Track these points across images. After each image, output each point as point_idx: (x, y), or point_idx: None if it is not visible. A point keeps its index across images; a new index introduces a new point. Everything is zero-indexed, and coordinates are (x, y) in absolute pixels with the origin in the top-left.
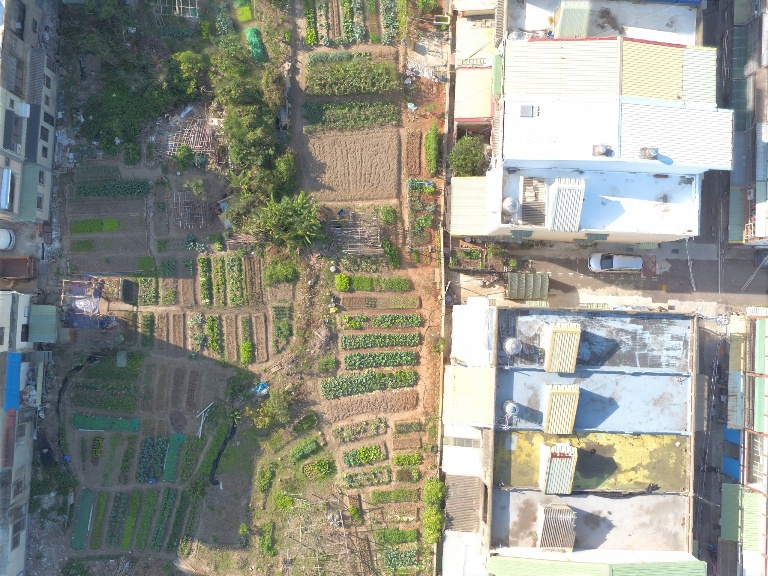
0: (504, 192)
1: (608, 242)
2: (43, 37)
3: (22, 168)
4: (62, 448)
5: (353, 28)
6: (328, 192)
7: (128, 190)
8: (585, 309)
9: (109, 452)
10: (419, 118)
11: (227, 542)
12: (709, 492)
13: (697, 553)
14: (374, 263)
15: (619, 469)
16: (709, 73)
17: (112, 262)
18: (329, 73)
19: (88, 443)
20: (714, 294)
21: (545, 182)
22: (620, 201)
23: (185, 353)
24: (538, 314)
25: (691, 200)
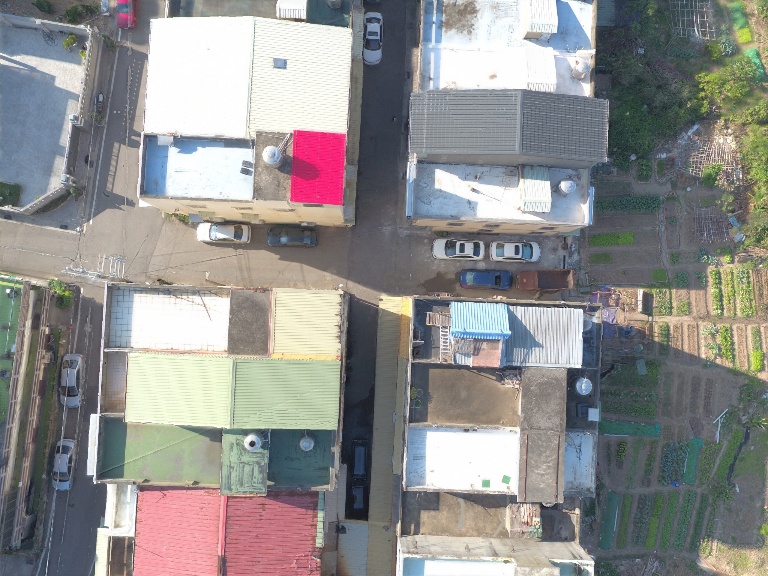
0: None
1: None
2: None
3: None
4: None
5: None
6: None
7: (643, 205)
8: None
9: (632, 456)
10: None
11: (744, 542)
12: None
13: None
14: None
15: None
16: None
17: (628, 274)
18: None
19: (612, 447)
20: None
21: None
22: None
23: (699, 361)
24: None
25: None
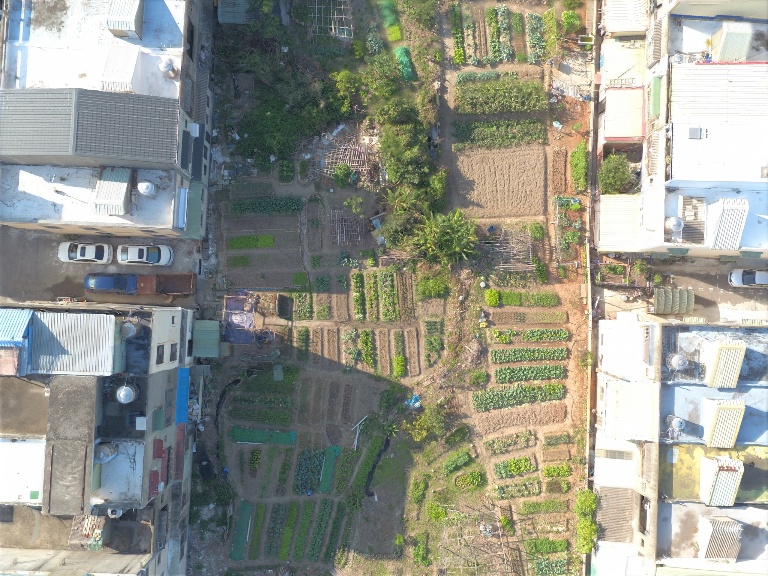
0: (664, 211)
1: (748, 258)
2: (200, 56)
3: (189, 186)
4: (221, 460)
5: (500, 48)
6: (477, 209)
7: (283, 207)
8: (745, 326)
9: (267, 464)
10: (564, 136)
11: (382, 552)
12: None
13: None
14: (523, 279)
15: None
16: None
17: (267, 278)
18: (480, 92)
19: (246, 455)
20: None
21: (704, 201)
22: None
23: (339, 367)
24: (698, 330)
25: None
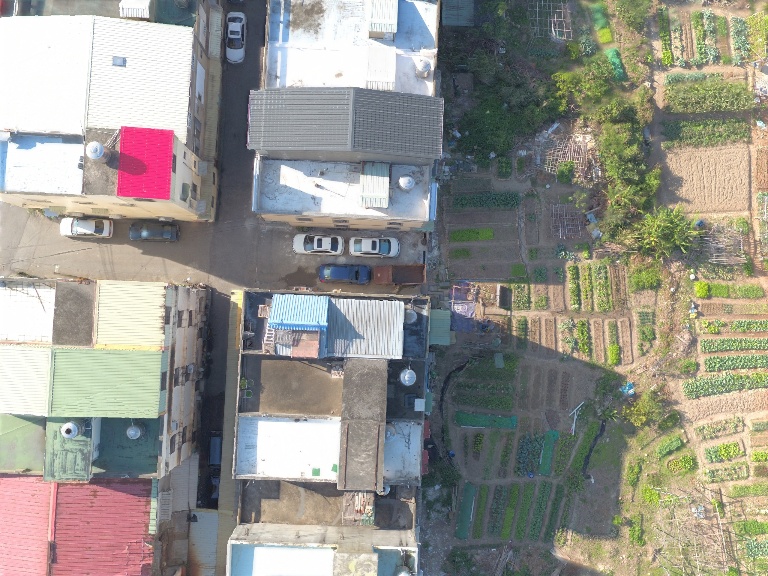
0: None
1: None
2: None
3: None
4: (446, 444)
5: (706, 50)
6: (685, 204)
7: (503, 202)
8: None
9: (489, 448)
10: (767, 135)
11: (599, 533)
12: None
13: None
14: (730, 271)
15: None
16: None
17: (487, 269)
18: (692, 93)
19: (470, 439)
20: None
21: None
22: None
23: (556, 355)
24: None
25: None
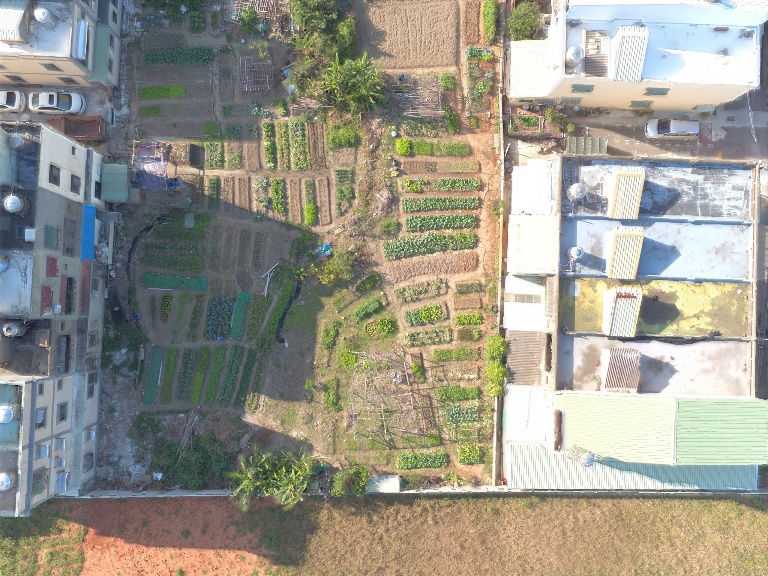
0: (567, 45)
1: (664, 109)
2: None
3: (95, 28)
4: (132, 306)
5: None
6: (389, 59)
7: (194, 57)
8: (648, 157)
9: (178, 310)
10: None
11: (293, 398)
12: (765, 355)
13: None
14: (434, 128)
15: (681, 315)
16: None
17: (179, 127)
18: None
19: (157, 302)
20: None
21: (607, 35)
22: (681, 54)
23: (250, 215)
24: (601, 164)
25: (752, 53)
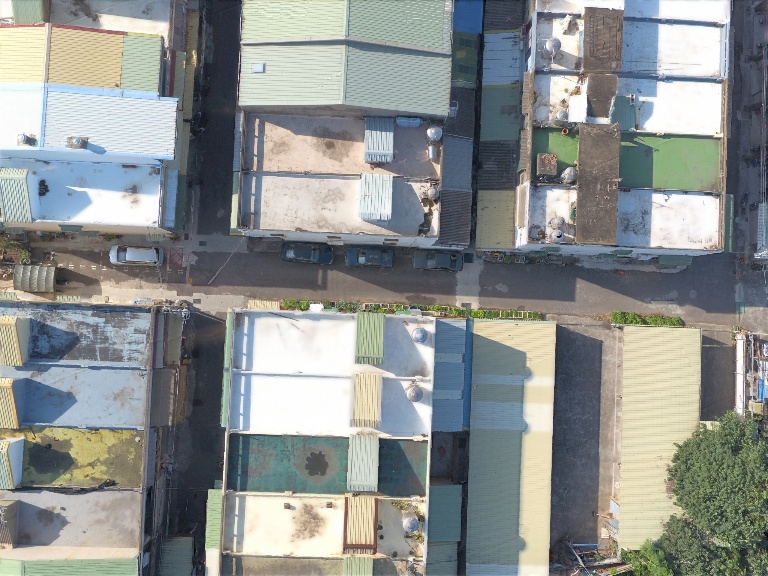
0: None
1: (132, 234)
2: None
3: None
4: None
5: None
6: None
7: None
8: (37, 301)
9: None
10: None
11: None
12: None
13: (191, 550)
14: None
15: (75, 464)
16: (152, 61)
17: None
18: None
19: None
20: (241, 287)
21: None
22: (87, 192)
23: None
24: None
25: None
